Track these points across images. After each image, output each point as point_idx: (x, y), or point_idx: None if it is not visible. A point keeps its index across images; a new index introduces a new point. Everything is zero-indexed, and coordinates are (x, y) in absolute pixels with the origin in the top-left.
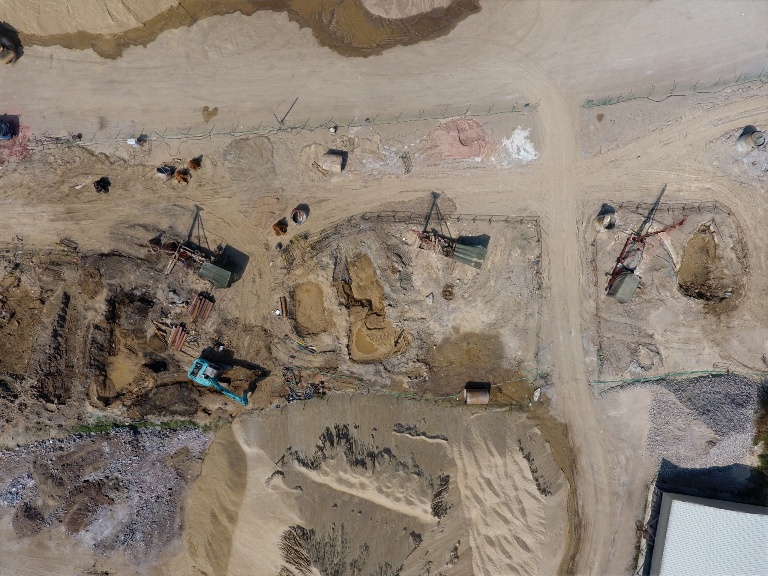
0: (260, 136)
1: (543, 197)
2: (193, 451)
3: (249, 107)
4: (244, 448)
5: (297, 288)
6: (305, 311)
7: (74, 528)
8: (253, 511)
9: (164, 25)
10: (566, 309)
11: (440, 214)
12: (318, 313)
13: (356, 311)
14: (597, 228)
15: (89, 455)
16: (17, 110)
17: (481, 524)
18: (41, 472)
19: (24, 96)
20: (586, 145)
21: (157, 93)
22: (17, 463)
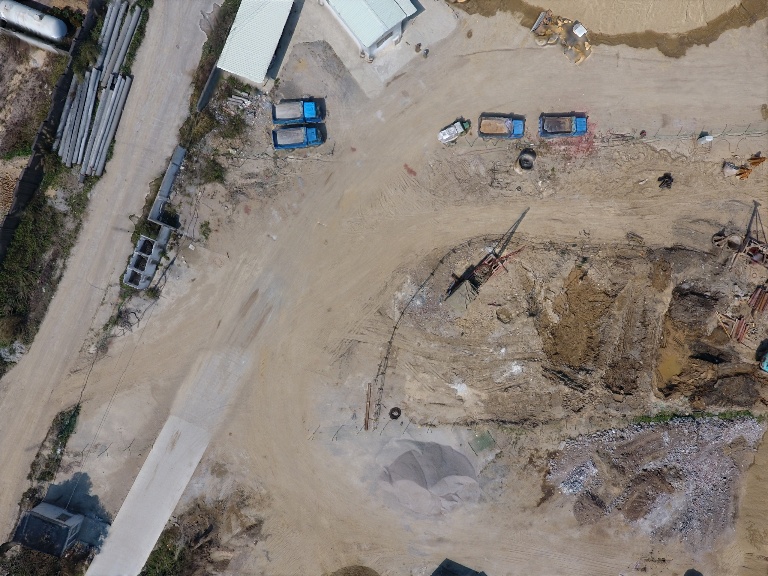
0: None
1: None
2: (749, 441)
3: None
4: None
5: None
6: None
7: (634, 516)
8: None
9: (726, 25)
10: None
11: None
12: None
13: None
14: None
15: (649, 444)
16: (584, 107)
17: None
18: (606, 461)
19: (591, 94)
20: None
21: (718, 91)
22: (581, 452)
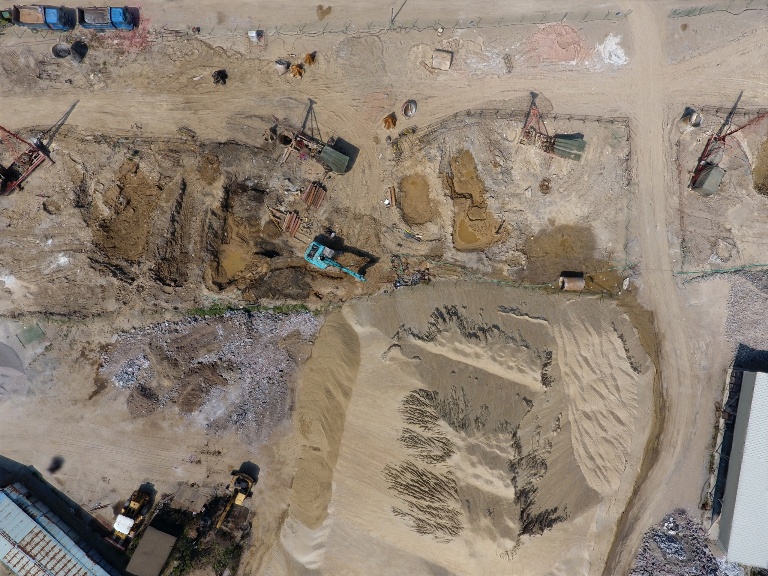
0: (371, 35)
1: (632, 100)
2: (304, 334)
3: (361, 7)
4: (356, 328)
5: (404, 180)
6: (411, 202)
7: (188, 408)
8: (369, 384)
9: None
10: (652, 204)
11: (538, 113)
12: (423, 204)
13: (460, 202)
14: (681, 129)
15: (203, 337)
16: (137, 3)
17: (579, 400)
18: (157, 353)
19: None
20: (671, 53)
21: None
22: (133, 345)
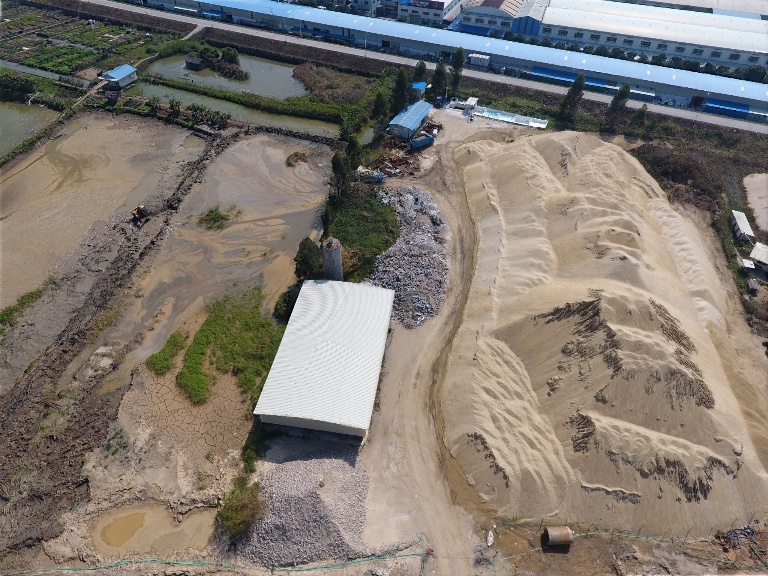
0: None
1: None
2: None
3: None
4: None
5: None
6: None
7: None
8: (738, 421)
9: None
10: None
11: None
12: None
13: None
14: None
15: None
16: None
17: (530, 409)
18: None
19: None
20: None
21: None
22: None
